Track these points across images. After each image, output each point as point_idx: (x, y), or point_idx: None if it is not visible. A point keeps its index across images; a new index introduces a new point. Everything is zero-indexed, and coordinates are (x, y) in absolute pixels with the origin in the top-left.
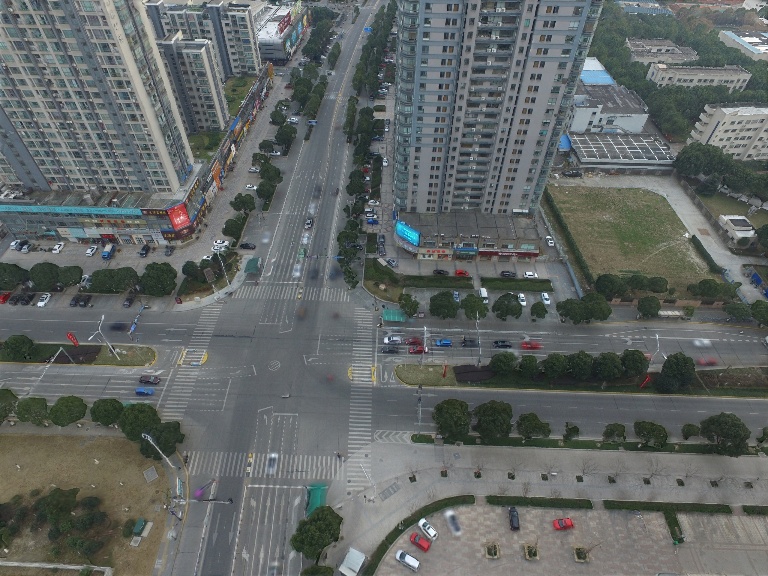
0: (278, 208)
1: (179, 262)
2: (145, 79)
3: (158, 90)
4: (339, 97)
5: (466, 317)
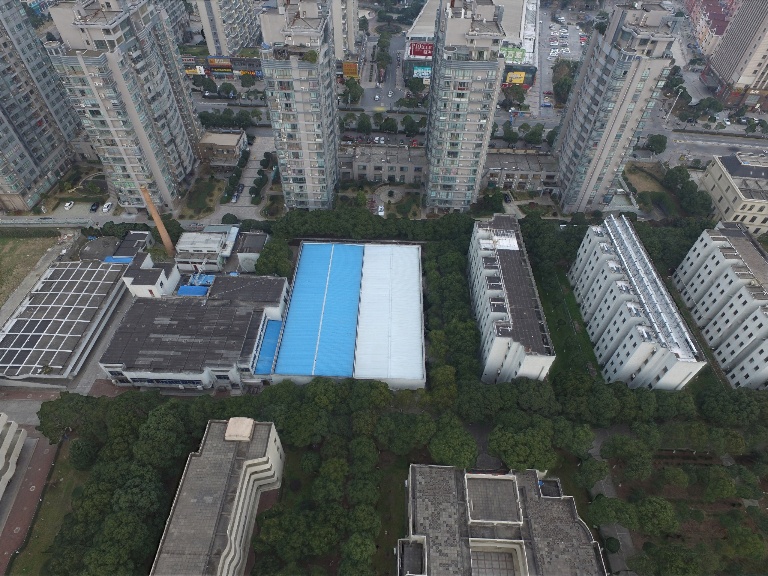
0: None
1: None
2: None
3: None
4: None
5: None
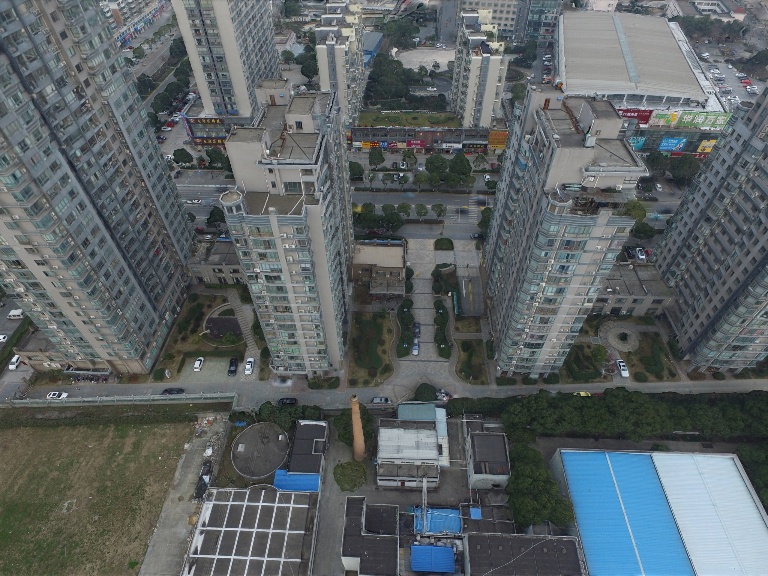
0: (228, 184)
1: (175, 148)
2: (191, 24)
3: (209, 39)
4: (476, 207)
5: (4, 300)
